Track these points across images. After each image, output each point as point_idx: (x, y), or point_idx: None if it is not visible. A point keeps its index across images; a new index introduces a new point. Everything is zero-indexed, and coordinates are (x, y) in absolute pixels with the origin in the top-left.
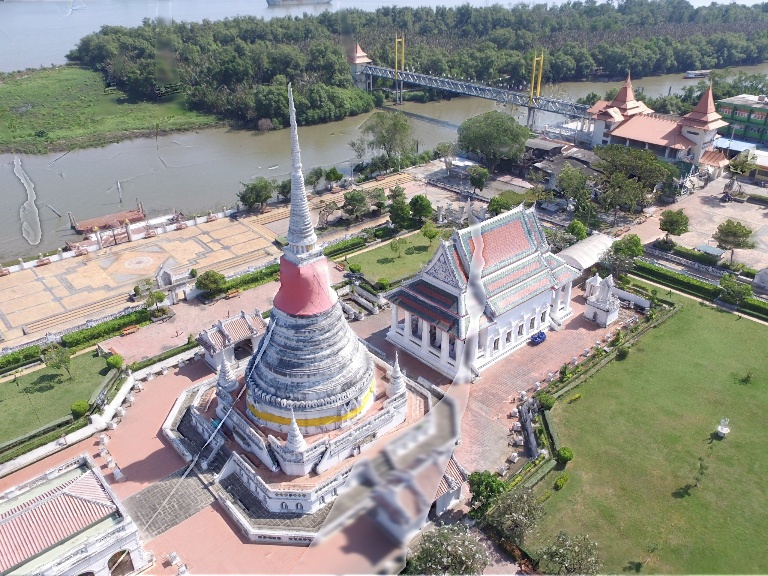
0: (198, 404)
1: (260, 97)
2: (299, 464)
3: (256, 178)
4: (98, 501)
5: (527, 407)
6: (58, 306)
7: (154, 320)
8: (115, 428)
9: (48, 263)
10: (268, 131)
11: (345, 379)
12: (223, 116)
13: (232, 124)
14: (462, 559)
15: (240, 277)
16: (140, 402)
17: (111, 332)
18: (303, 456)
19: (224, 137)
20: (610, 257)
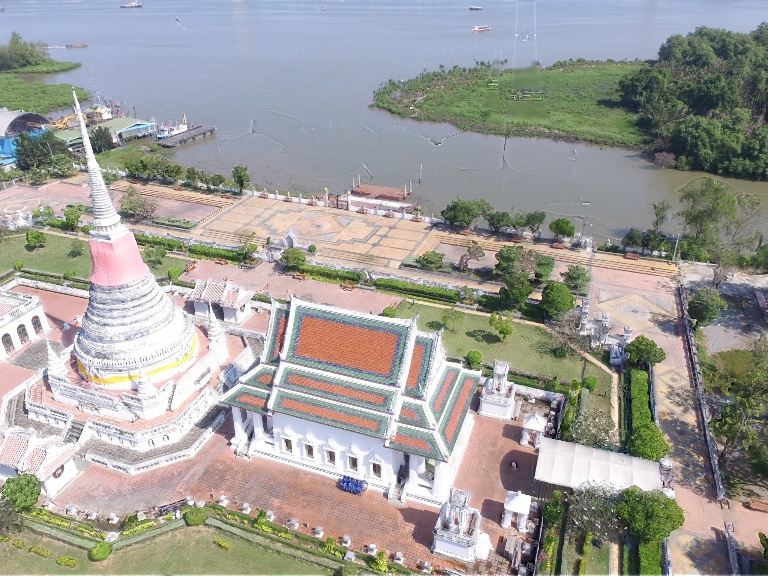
0: None
1: (681, 127)
2: None
3: (476, 198)
4: None
5: (192, 505)
6: (238, 228)
7: (241, 264)
8: None
9: (291, 201)
10: (666, 168)
11: (102, 349)
12: (653, 139)
13: None
14: None
15: (322, 267)
16: None
17: (217, 257)
18: (50, 378)
19: (620, 160)
20: None
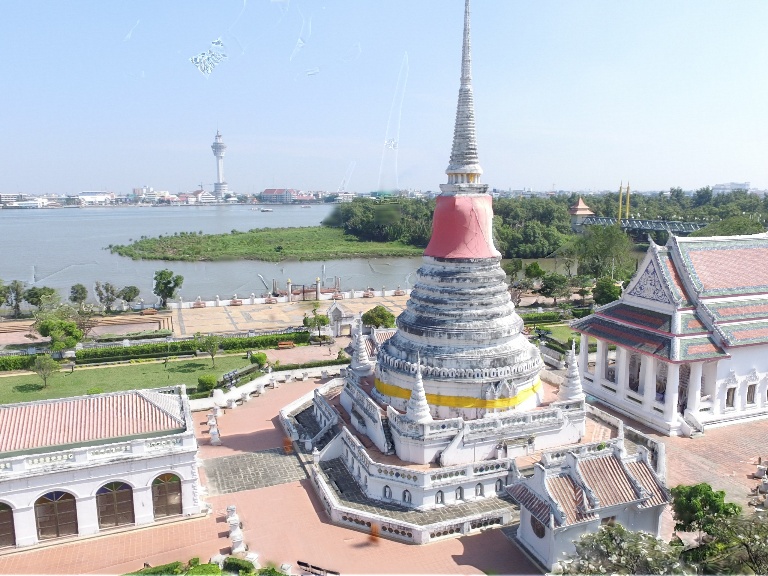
0: (324, 393)
1: None
2: (418, 443)
3: None
4: (168, 411)
5: None
6: (232, 326)
7: (312, 342)
8: (234, 407)
9: (240, 305)
10: None
11: (498, 354)
12: None
13: None
14: (646, 562)
15: None
16: (269, 395)
17: (268, 345)
18: (424, 431)
19: None
20: None
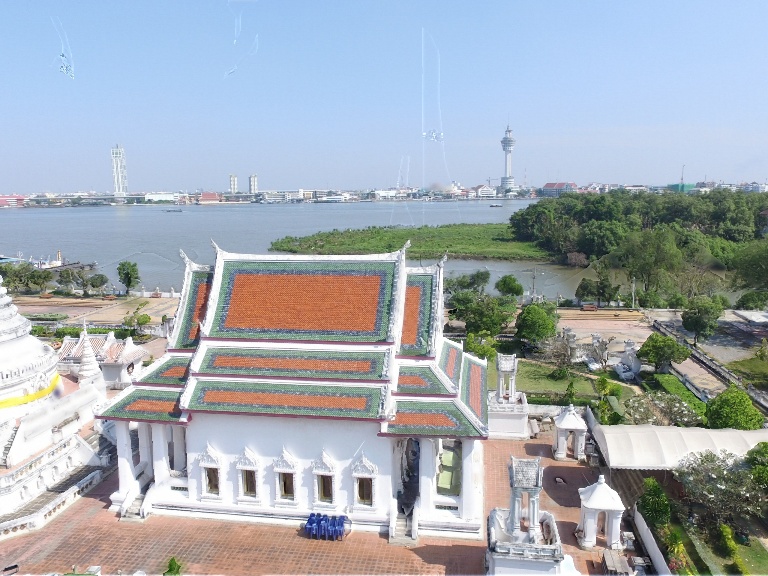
0: None
1: (585, 231)
2: None
3: None
4: None
5: None
6: None
7: None
8: None
9: None
10: (580, 268)
11: None
12: (557, 253)
13: (556, 260)
14: None
15: None
16: None
17: None
18: None
19: None
20: (687, 461)
